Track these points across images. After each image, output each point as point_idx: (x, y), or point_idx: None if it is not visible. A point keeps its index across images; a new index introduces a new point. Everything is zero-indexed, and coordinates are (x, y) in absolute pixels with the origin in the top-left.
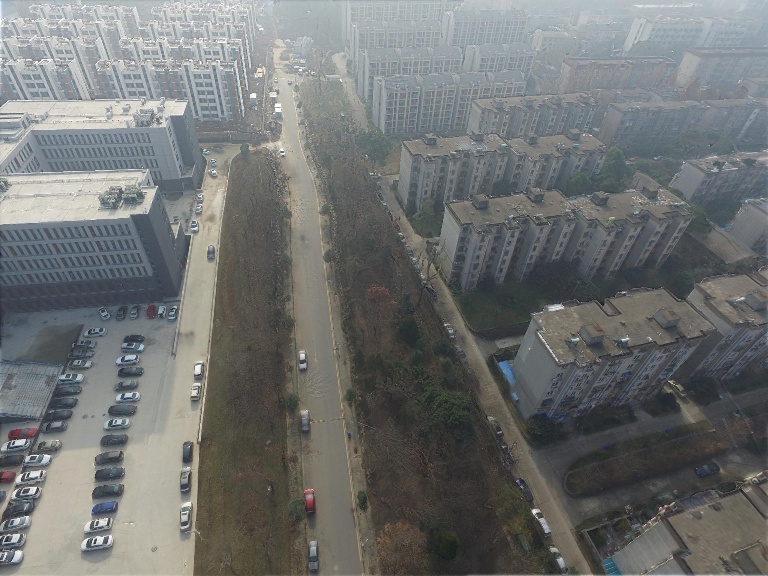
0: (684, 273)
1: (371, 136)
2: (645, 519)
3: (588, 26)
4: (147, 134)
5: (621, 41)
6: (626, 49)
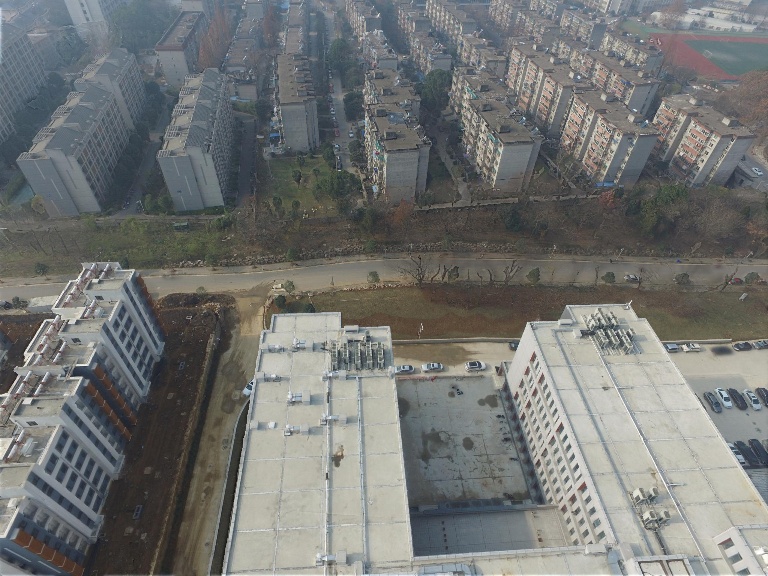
0: None
1: (341, 178)
2: None
3: (21, 20)
4: None
5: (63, 22)
6: None
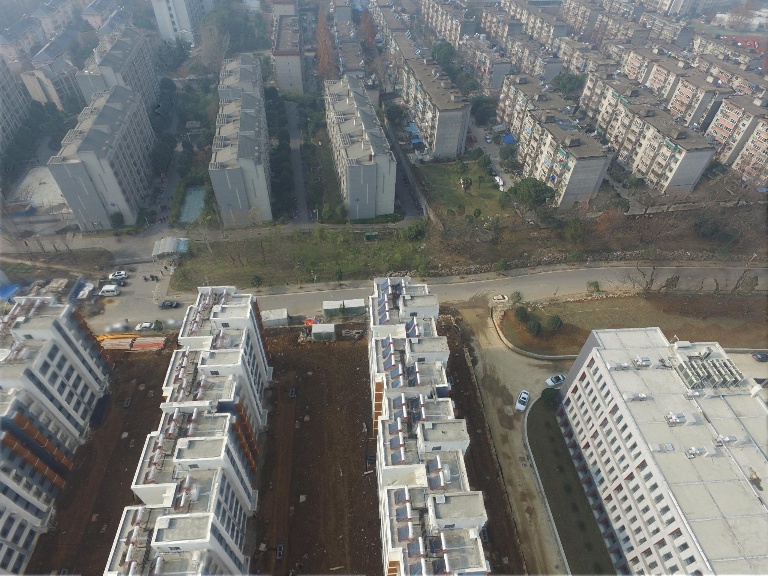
0: None
1: (536, 186)
2: None
3: None
4: None
5: (148, 26)
6: (166, 31)
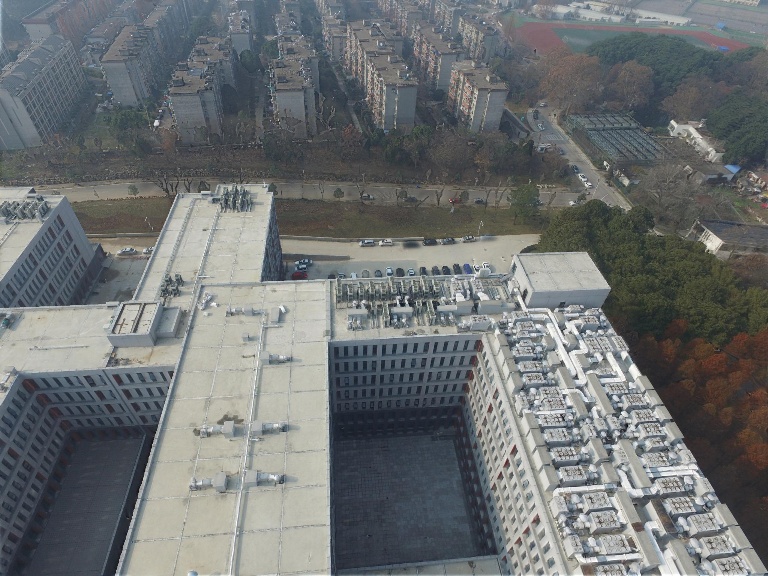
0: (328, 70)
1: (125, 116)
2: (453, 125)
3: None
4: (58, 217)
5: None
6: None
